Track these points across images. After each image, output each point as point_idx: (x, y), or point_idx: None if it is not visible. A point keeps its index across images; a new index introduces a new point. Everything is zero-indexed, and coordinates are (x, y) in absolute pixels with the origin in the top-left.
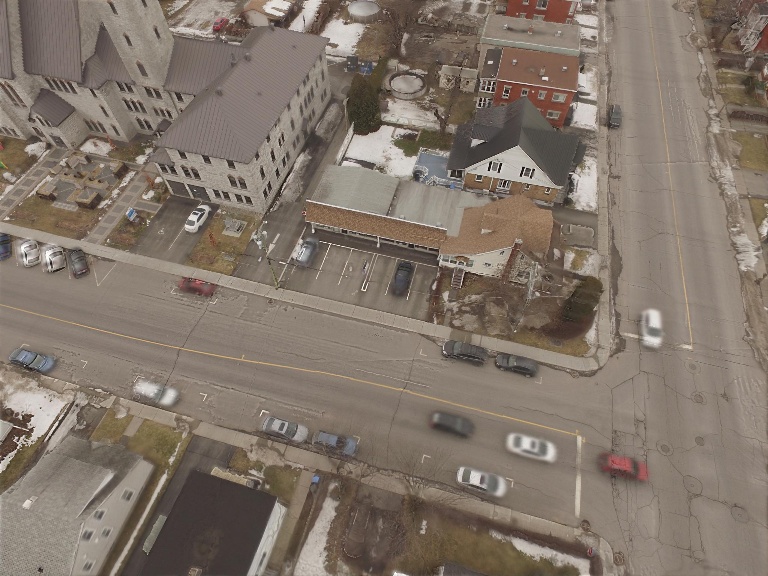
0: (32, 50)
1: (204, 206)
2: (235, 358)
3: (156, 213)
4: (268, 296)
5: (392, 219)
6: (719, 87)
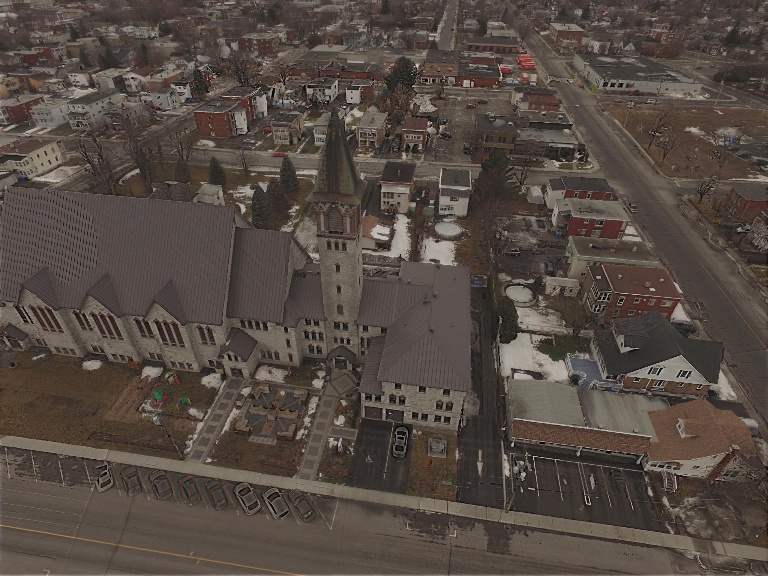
0: (237, 298)
1: (402, 428)
2: None
3: (355, 439)
4: (502, 521)
5: (598, 431)
6: (760, 280)
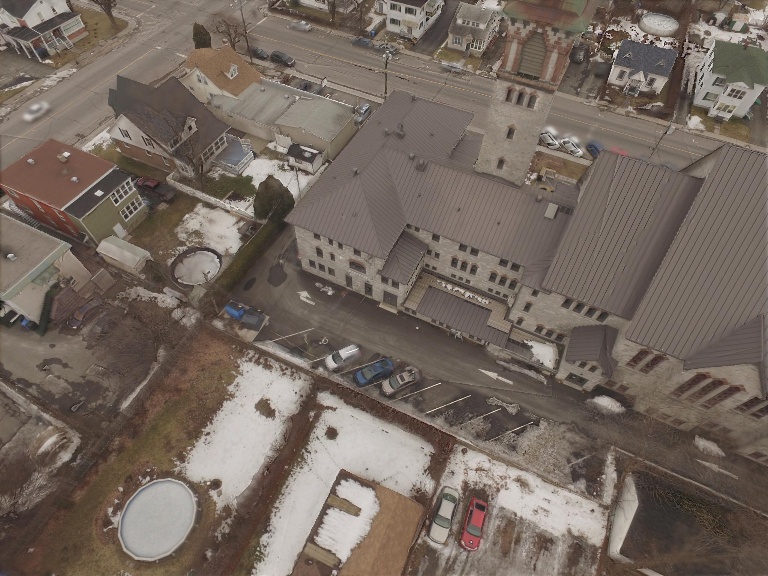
0: None
1: None
2: (412, 77)
3: None
4: None
5: None
6: None
